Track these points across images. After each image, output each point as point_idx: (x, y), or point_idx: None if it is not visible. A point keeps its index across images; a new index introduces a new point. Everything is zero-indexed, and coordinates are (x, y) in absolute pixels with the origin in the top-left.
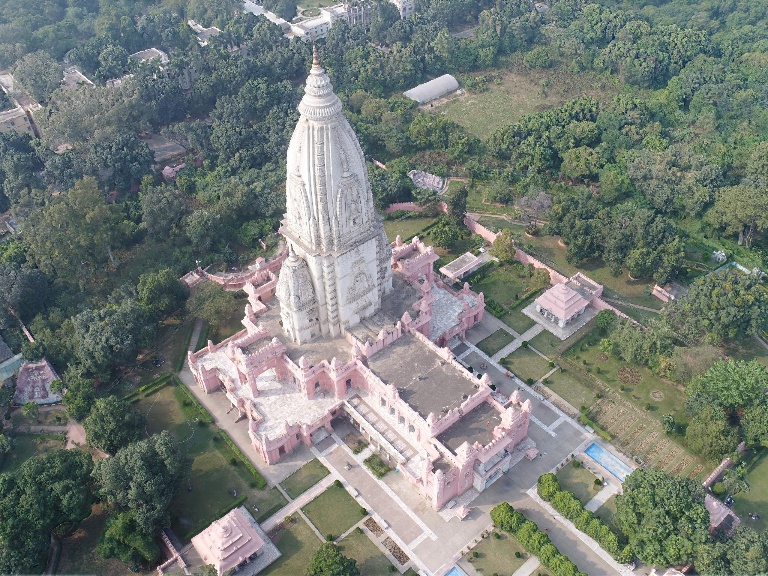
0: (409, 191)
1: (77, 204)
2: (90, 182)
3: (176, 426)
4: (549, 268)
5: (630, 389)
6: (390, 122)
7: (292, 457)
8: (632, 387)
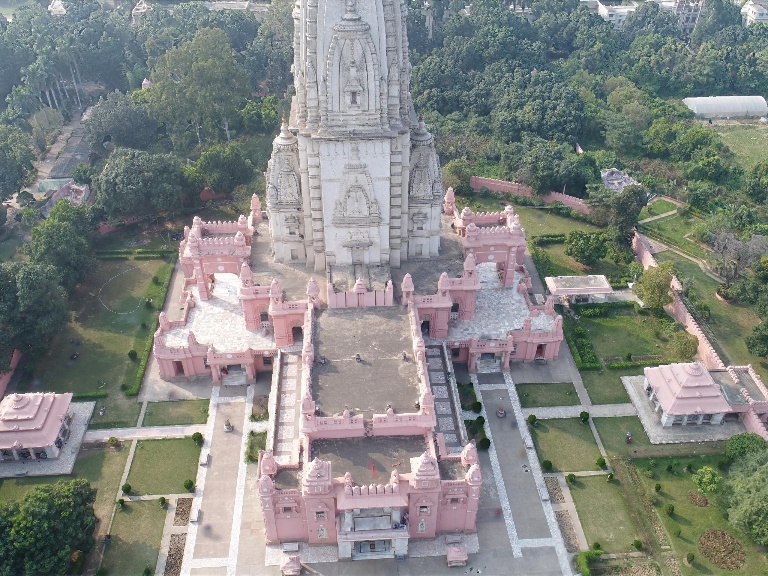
0: (585, 184)
1: (197, 52)
2: (220, 36)
3: (129, 296)
4: (707, 341)
5: (706, 569)
6: (630, 114)
7: (189, 384)
8: (713, 568)
